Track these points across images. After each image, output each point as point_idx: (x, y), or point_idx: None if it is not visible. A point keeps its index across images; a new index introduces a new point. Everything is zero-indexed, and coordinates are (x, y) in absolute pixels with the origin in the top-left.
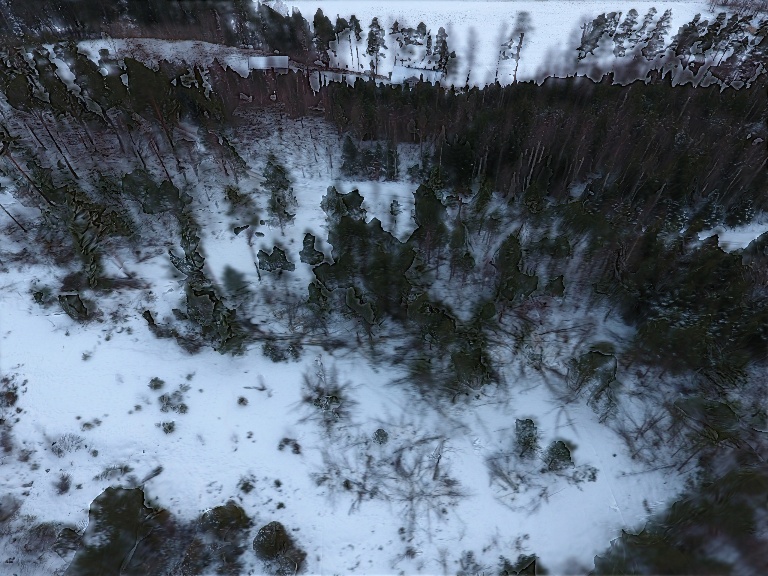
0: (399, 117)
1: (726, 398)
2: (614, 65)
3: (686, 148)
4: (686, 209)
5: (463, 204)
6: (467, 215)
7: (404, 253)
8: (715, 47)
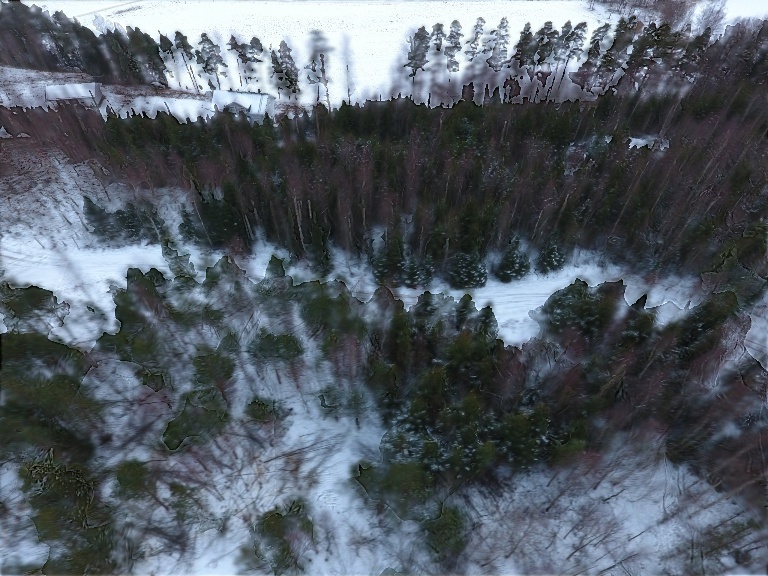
0: (178, 161)
1: (480, 532)
2: (486, 71)
3: (496, 183)
4: (489, 259)
5: (194, 286)
6: (192, 303)
7: (53, 384)
8: (555, 57)
